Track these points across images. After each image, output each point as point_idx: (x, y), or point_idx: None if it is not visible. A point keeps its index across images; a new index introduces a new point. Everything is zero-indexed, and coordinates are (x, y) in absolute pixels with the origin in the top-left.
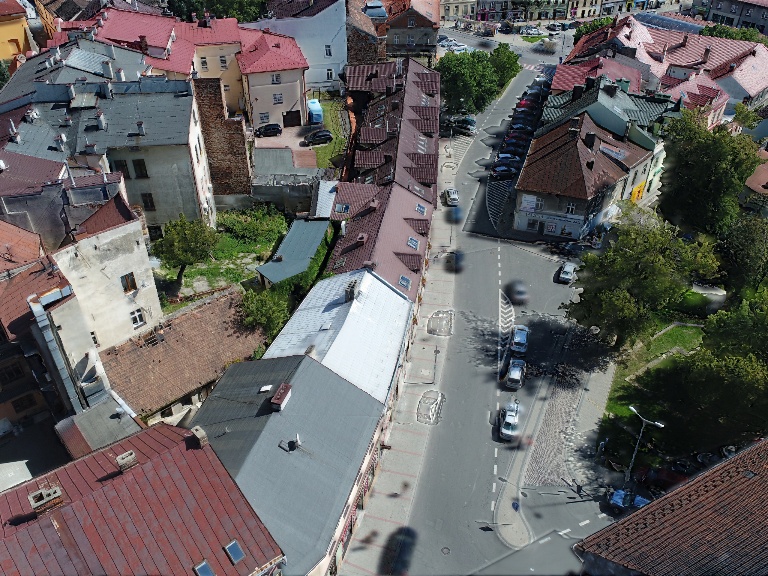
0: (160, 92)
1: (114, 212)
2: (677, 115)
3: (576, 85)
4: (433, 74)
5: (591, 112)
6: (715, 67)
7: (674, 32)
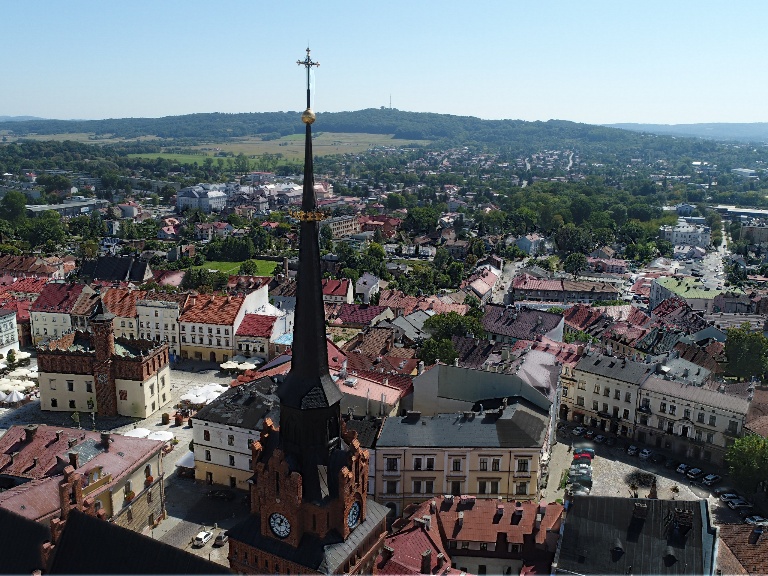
0: (671, 359)
1: (765, 392)
2: (691, 336)
3: (661, 332)
4: (598, 343)
5: (680, 341)
6: (627, 319)
7: (598, 307)
